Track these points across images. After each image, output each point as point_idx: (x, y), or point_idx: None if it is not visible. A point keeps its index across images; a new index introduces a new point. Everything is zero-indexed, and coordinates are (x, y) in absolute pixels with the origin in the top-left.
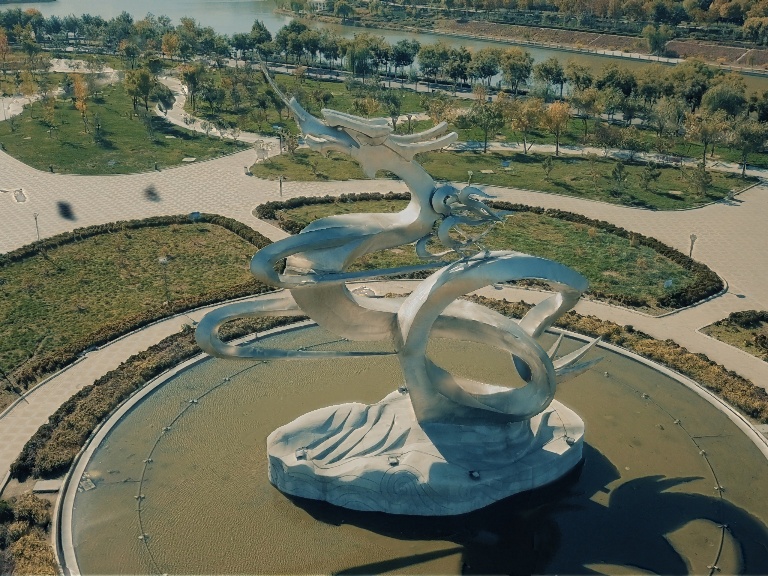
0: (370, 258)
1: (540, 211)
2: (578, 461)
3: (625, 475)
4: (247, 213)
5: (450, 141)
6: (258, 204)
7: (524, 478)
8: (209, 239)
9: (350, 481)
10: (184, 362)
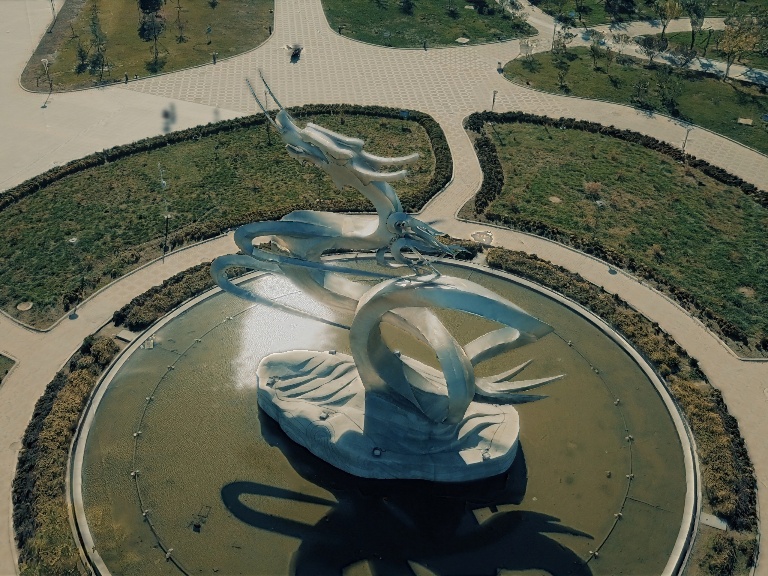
0: (523, 201)
1: (749, 190)
2: (497, 474)
3: (525, 504)
4: (459, 119)
5: (398, 178)
6: (477, 110)
7: (426, 470)
8: (404, 141)
9: (288, 417)
10: None
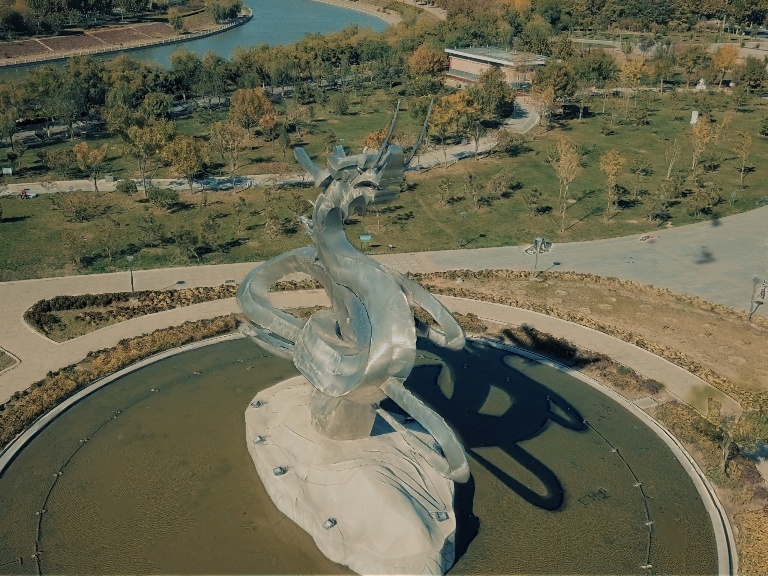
0: None
1: None
2: None
3: None
4: None
5: None
6: None
7: None
8: None
9: None
10: None
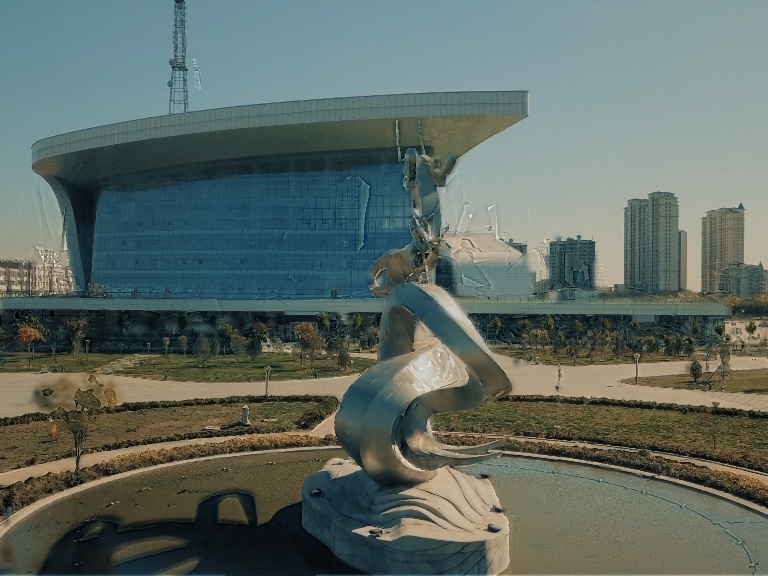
0: None
1: None
2: None
3: None
4: None
5: None
6: None
7: None
8: None
9: None
10: (578, 459)
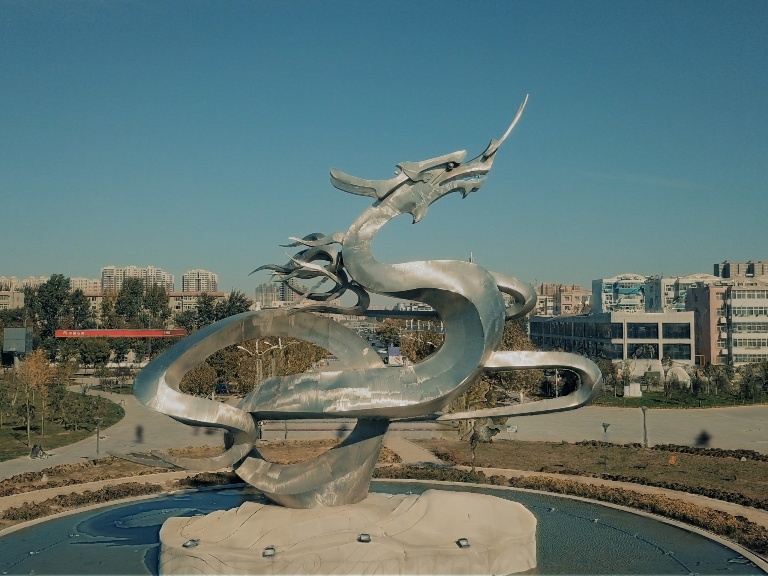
0: None
1: None
2: None
3: None
4: None
5: None
6: None
7: None
8: None
9: None
10: None
